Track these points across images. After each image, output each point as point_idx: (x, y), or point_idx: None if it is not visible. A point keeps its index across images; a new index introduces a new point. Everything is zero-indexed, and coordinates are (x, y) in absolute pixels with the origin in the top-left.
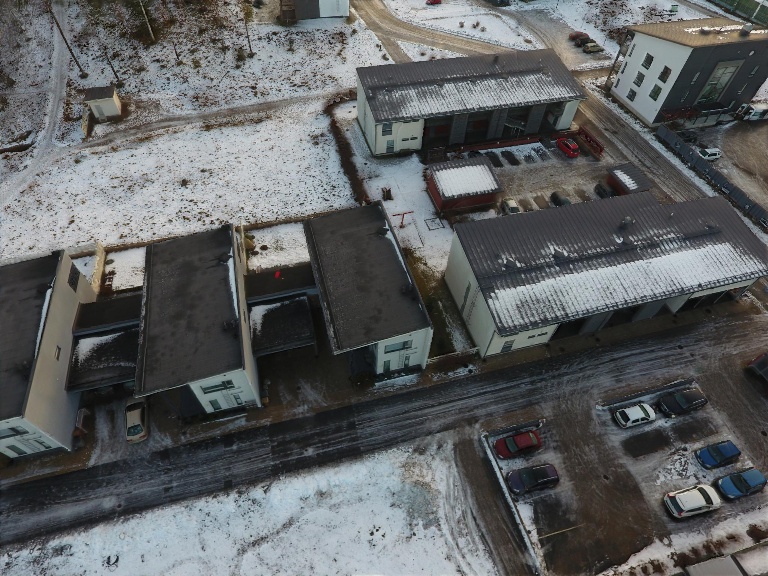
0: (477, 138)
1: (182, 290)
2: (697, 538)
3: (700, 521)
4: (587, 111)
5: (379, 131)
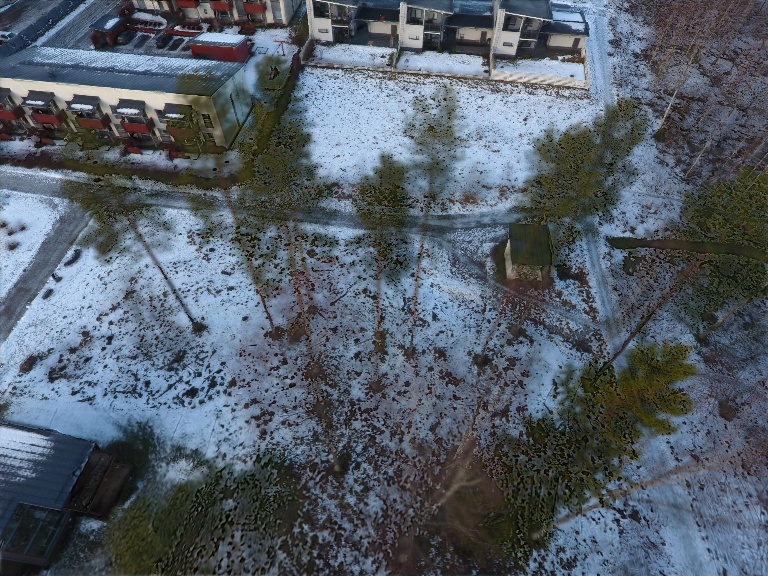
0: None
1: None
2: None
3: None
4: None
5: None
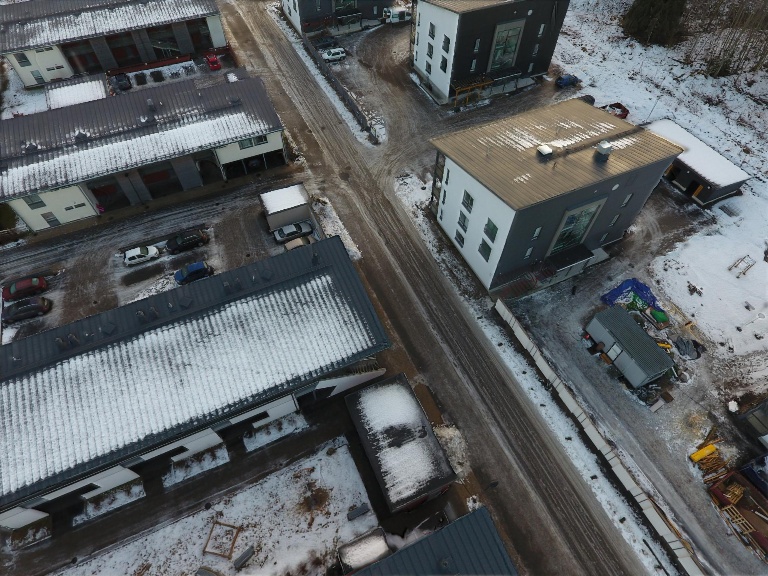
0: (134, 63)
1: None
2: None
3: None
4: (255, 30)
5: (14, 62)
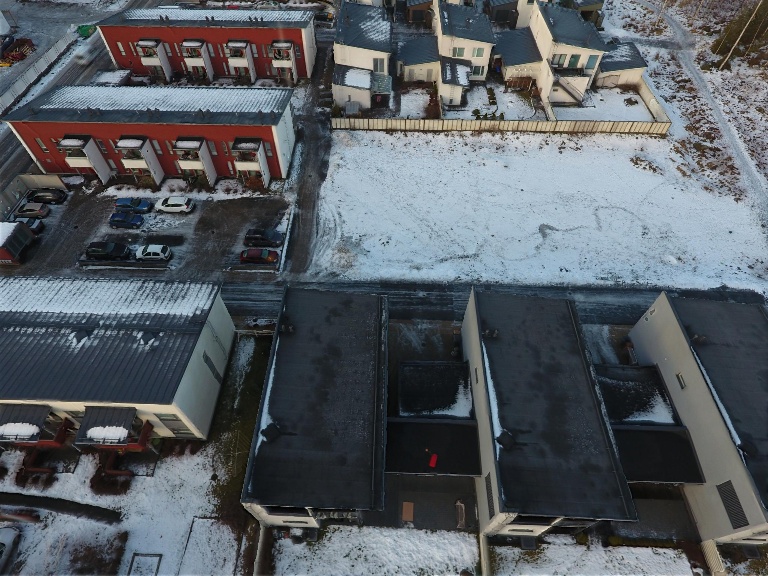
0: None
1: (557, 406)
2: (191, 196)
3: None
4: None
5: None
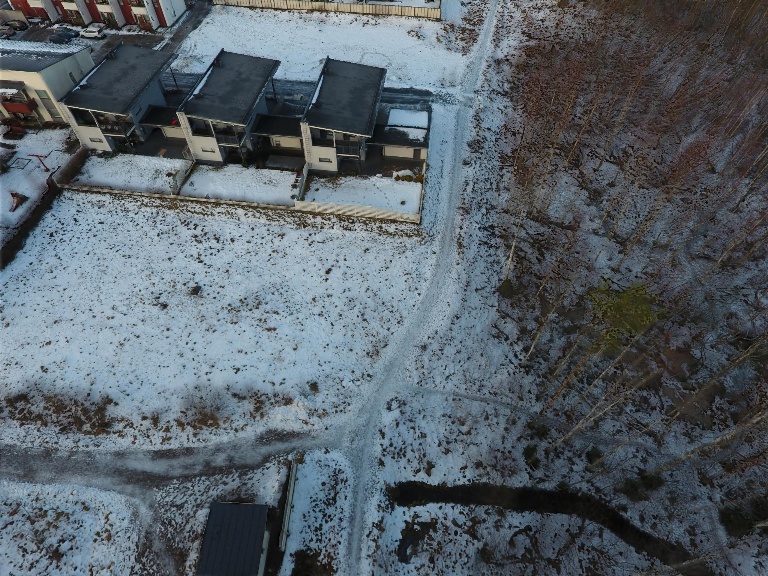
0: None
1: (236, 90)
2: (106, 31)
3: None
4: None
5: None
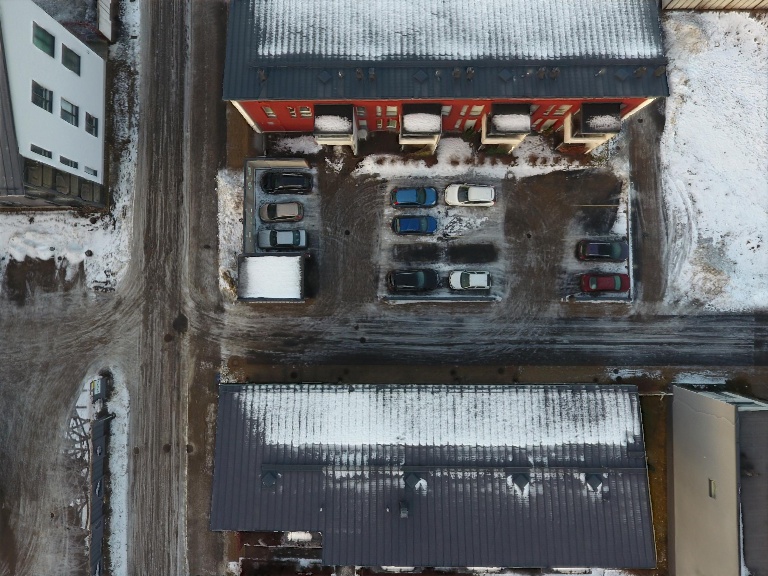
0: None
1: None
2: (483, 171)
3: (470, 181)
4: None
5: None
